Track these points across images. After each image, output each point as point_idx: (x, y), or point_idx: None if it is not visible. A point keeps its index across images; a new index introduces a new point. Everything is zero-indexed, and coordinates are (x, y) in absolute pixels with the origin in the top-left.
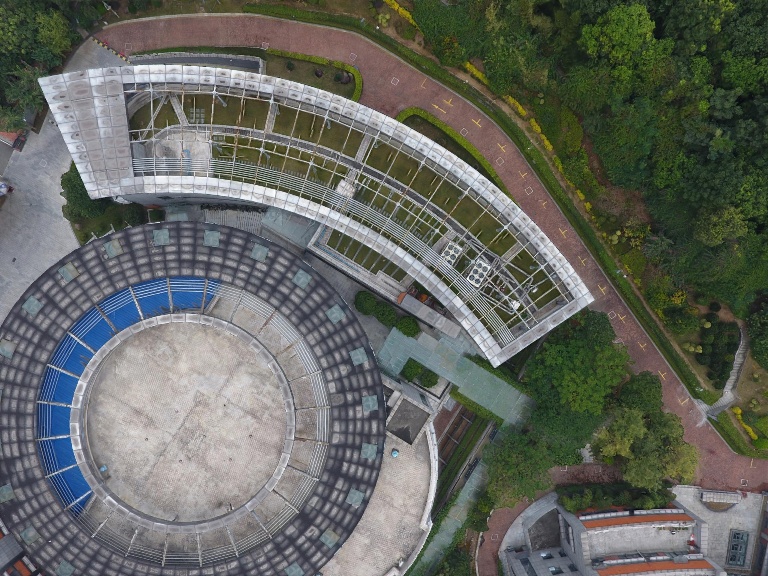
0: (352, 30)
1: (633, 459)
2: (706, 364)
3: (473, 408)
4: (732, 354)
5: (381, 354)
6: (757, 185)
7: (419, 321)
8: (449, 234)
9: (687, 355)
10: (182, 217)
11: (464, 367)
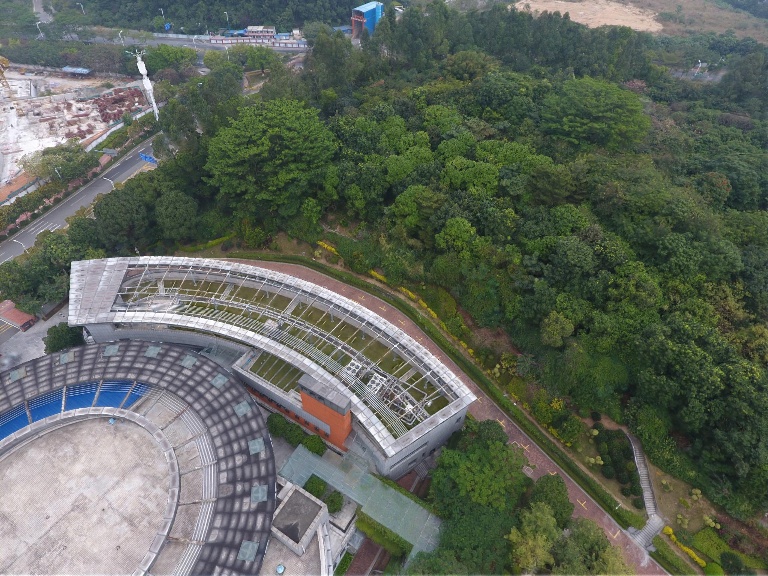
0: (298, 264)
1: (555, 564)
2: (614, 478)
3: (380, 538)
4: (631, 461)
5: (284, 471)
6: None
7: (328, 448)
8: None
9: (595, 474)
10: None
11: (368, 484)
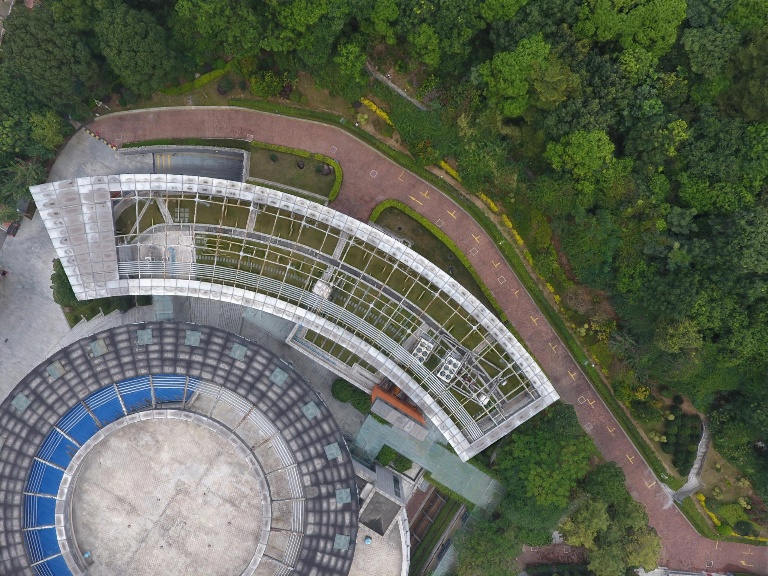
0: (333, 124)
1: (597, 550)
2: (671, 453)
3: None
4: (695, 445)
5: (357, 441)
6: (712, 299)
7: None
8: (421, 333)
9: (653, 442)
10: (167, 305)
11: (437, 453)
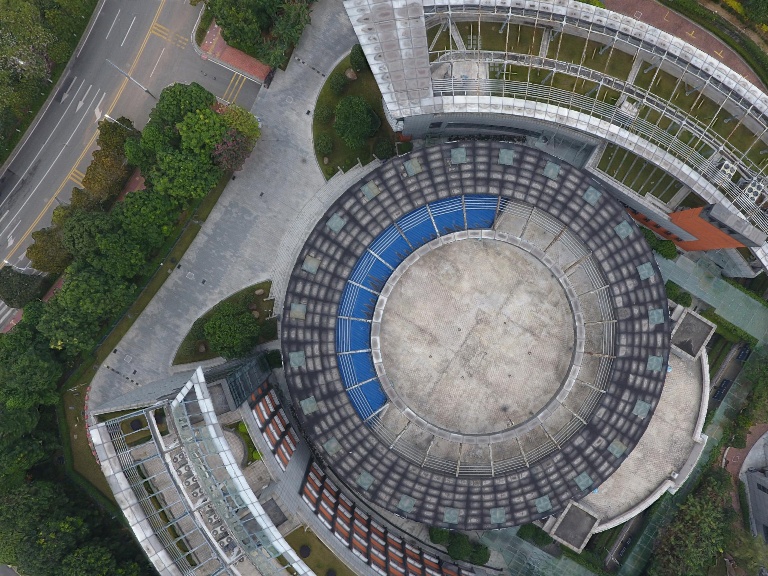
0: None
1: None
2: None
3: (723, 331)
4: None
5: None
6: None
7: None
8: None
9: None
10: None
11: (720, 289)
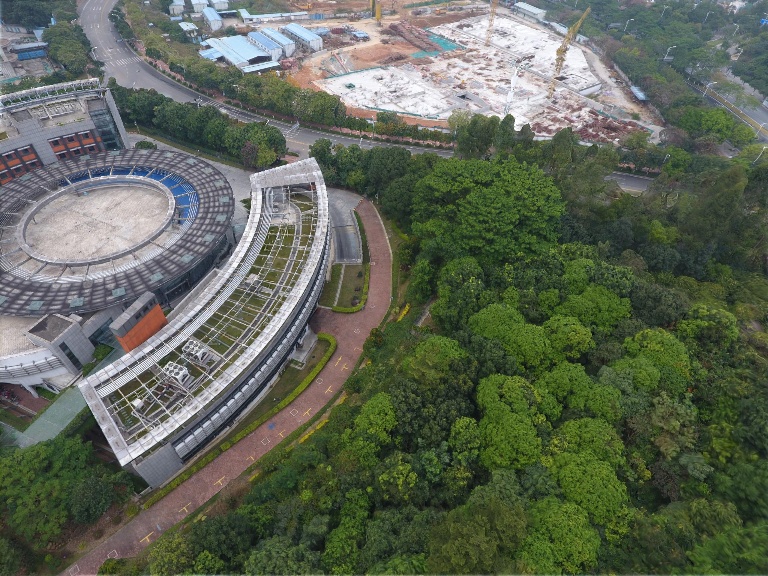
0: None
1: None
2: None
3: None
4: None
5: None
6: None
7: None
8: None
9: None
10: None
11: None
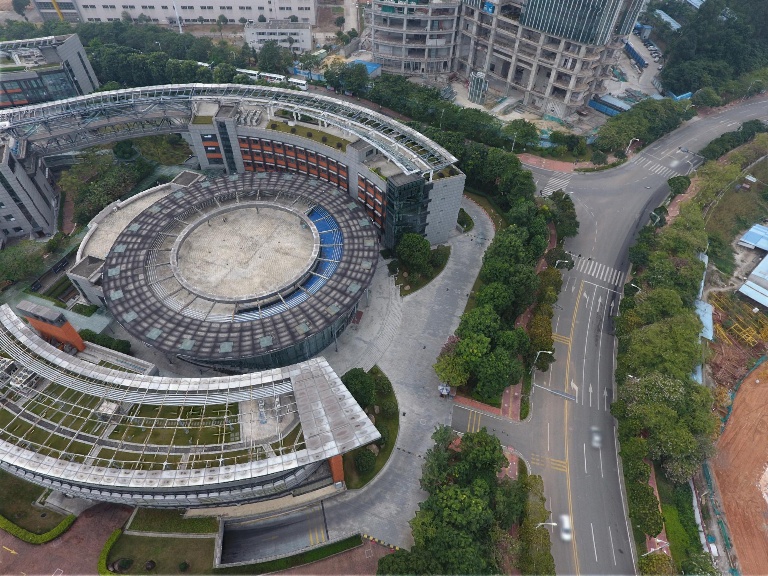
0: None
1: None
2: None
3: None
4: None
5: None
6: None
7: None
8: None
9: None
10: None
11: None
